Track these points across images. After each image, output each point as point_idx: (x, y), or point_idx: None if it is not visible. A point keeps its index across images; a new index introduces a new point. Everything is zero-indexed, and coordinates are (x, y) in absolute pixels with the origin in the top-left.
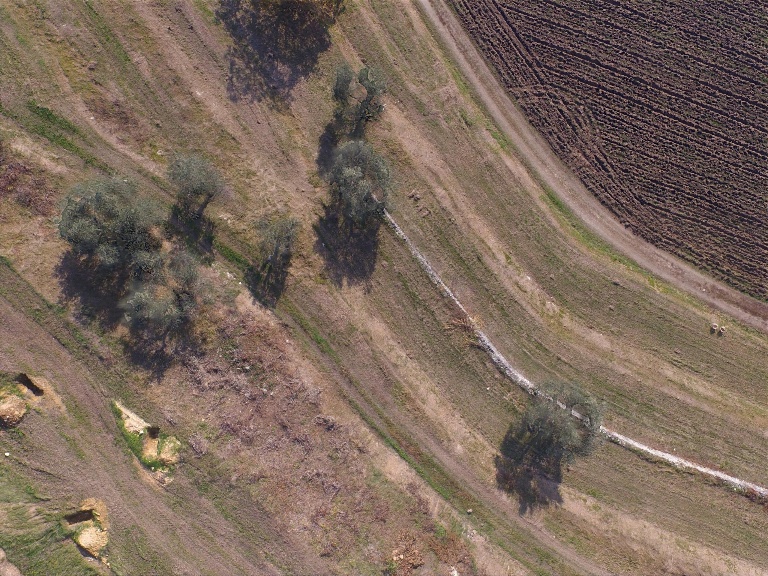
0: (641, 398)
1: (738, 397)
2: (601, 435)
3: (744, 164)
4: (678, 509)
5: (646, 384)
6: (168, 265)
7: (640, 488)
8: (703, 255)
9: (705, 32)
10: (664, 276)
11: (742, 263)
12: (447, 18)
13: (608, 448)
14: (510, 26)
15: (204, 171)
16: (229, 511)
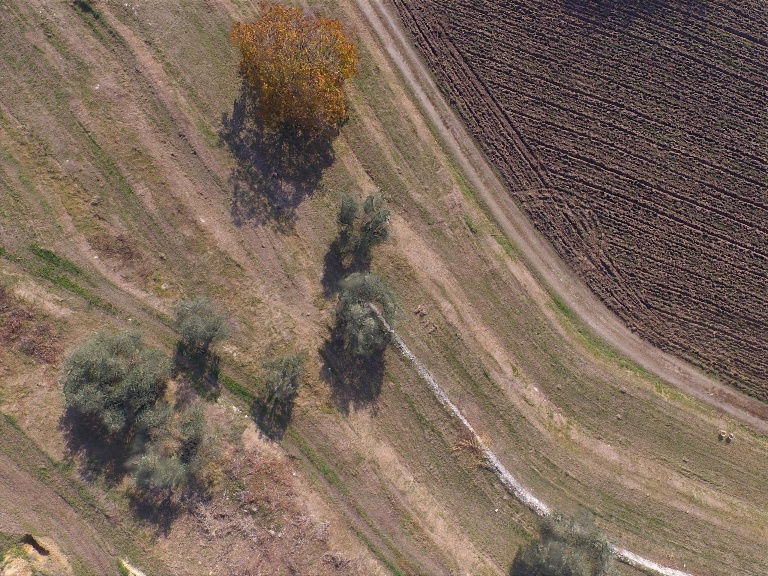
0: (650, 513)
1: (747, 506)
2: (611, 555)
3: (750, 267)
4: None
5: (655, 498)
6: (174, 406)
7: None
8: (710, 359)
9: (710, 133)
10: (671, 381)
11: (749, 367)
12: (451, 122)
13: (618, 568)
14: (514, 129)
15: (209, 303)
16: None
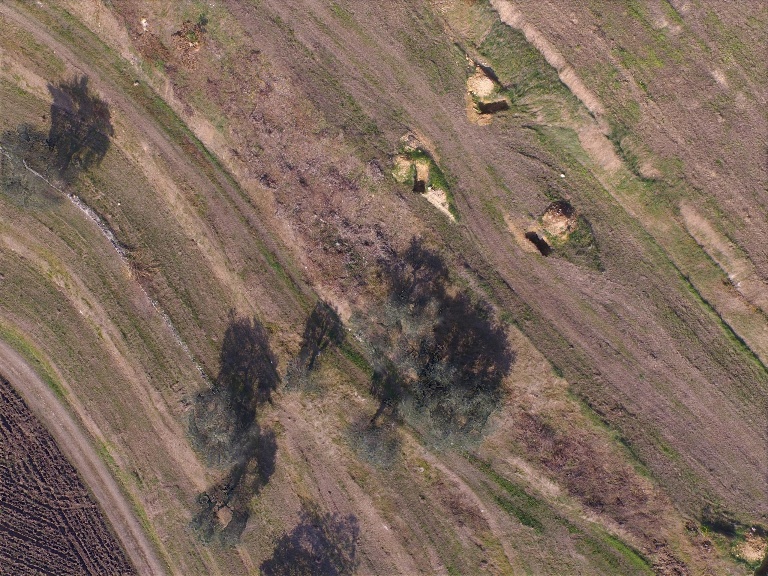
0: None
1: None
2: None
3: None
4: None
5: None
6: None
7: None
8: None
9: None
10: None
11: None
12: None
13: (4, 136)
14: (89, 572)
15: None
16: (347, 103)
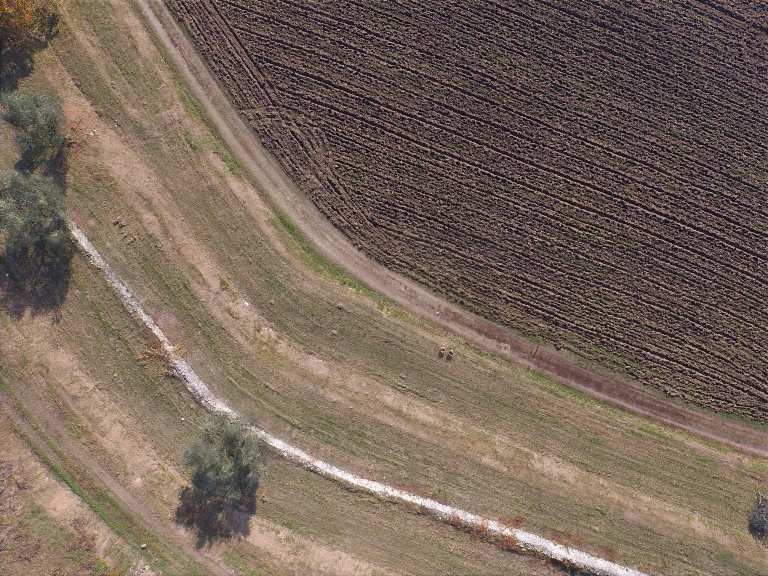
0: (352, 425)
1: (464, 422)
2: (300, 465)
3: (478, 185)
4: (379, 539)
5: (358, 411)
6: None
7: (340, 518)
8: (437, 277)
9: (441, 51)
10: (397, 299)
11: (476, 285)
12: (179, 40)
13: (307, 478)
14: (242, 47)
15: None
16: None
